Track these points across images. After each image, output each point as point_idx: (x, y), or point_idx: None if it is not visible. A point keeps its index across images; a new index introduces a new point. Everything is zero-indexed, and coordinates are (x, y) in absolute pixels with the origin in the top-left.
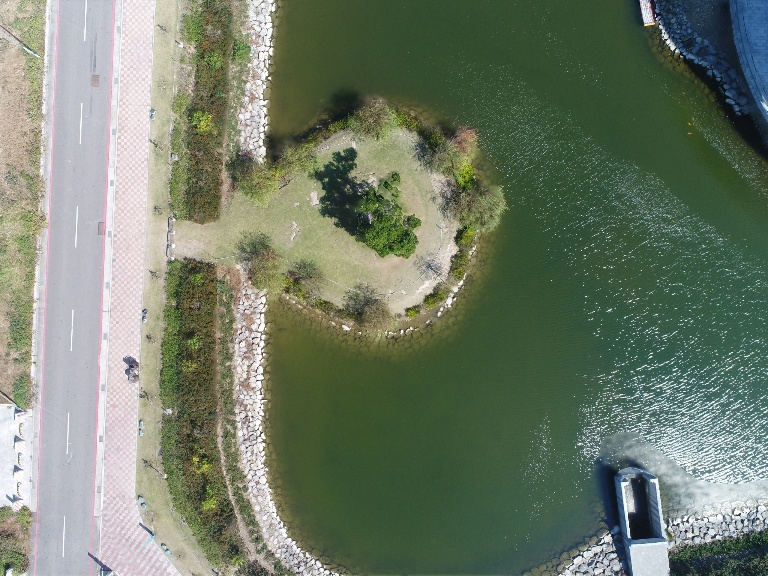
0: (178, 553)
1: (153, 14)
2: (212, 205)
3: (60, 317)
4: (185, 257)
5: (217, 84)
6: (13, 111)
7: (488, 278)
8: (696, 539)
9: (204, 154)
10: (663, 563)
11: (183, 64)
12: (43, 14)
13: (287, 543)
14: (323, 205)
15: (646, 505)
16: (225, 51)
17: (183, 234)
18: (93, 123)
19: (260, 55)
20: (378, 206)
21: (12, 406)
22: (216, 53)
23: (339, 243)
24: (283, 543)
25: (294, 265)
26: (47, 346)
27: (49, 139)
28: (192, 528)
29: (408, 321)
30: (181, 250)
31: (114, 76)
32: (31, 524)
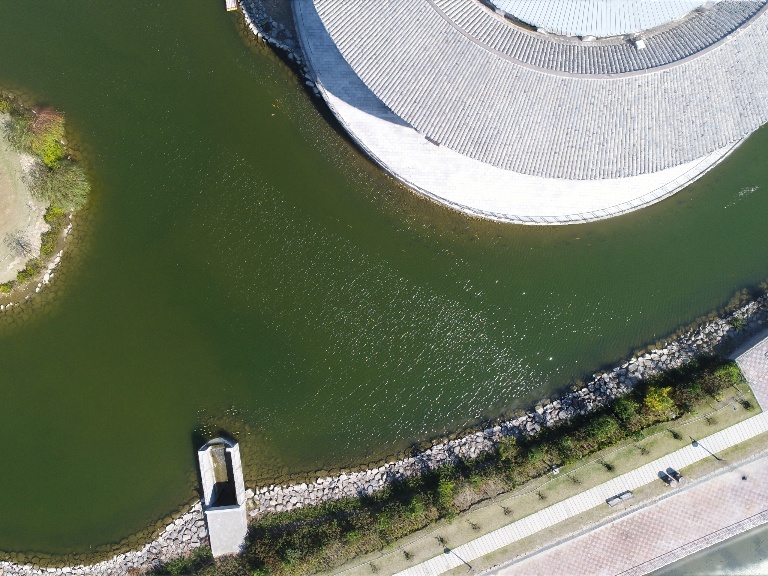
0: None
1: None
2: None
3: None
4: None
5: None
6: None
7: (87, 255)
8: (278, 507)
9: None
10: (238, 529)
11: None
12: None
13: None
14: None
15: None
16: None
17: None
18: None
19: None
20: None
21: None
22: None
23: None
24: None
25: None
26: None
27: None
28: None
29: (8, 297)
30: None
31: None
32: None
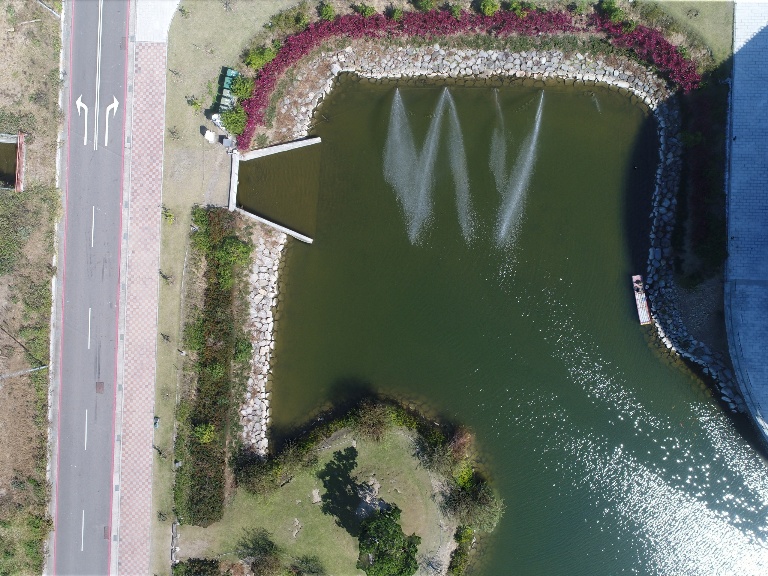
0: None
1: (156, 322)
2: (215, 511)
3: None
4: (189, 558)
5: (219, 391)
6: (19, 417)
7: (488, 566)
8: None
9: (207, 462)
10: None
11: (186, 371)
12: (48, 322)
13: None
14: (324, 503)
15: None
16: (227, 358)
17: (187, 536)
18: (98, 429)
19: (261, 350)
20: (378, 544)
21: None
22: (218, 364)
23: (340, 541)
24: None
25: (296, 561)
26: None
27: (55, 444)
28: None
29: None
30: (185, 552)
31: (118, 383)
32: None
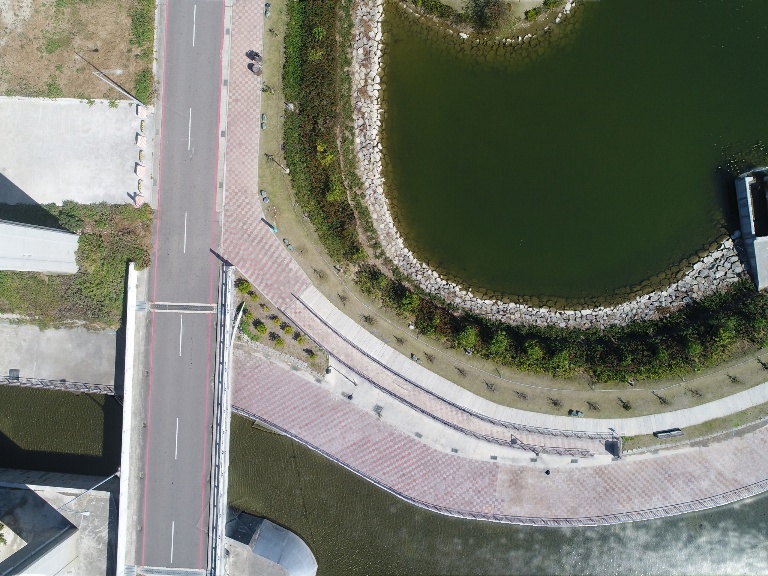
0: (300, 248)
1: None
2: None
3: (182, 13)
4: None
5: None
6: None
7: None
8: None
9: None
10: None
11: None
12: None
13: (404, 253)
14: None
15: (766, 212)
16: None
17: None
18: None
19: None
20: None
21: (133, 103)
22: None
23: None
24: (400, 252)
25: None
26: (169, 42)
27: None
28: (315, 221)
29: (526, 28)
30: None
31: None
32: (152, 221)
